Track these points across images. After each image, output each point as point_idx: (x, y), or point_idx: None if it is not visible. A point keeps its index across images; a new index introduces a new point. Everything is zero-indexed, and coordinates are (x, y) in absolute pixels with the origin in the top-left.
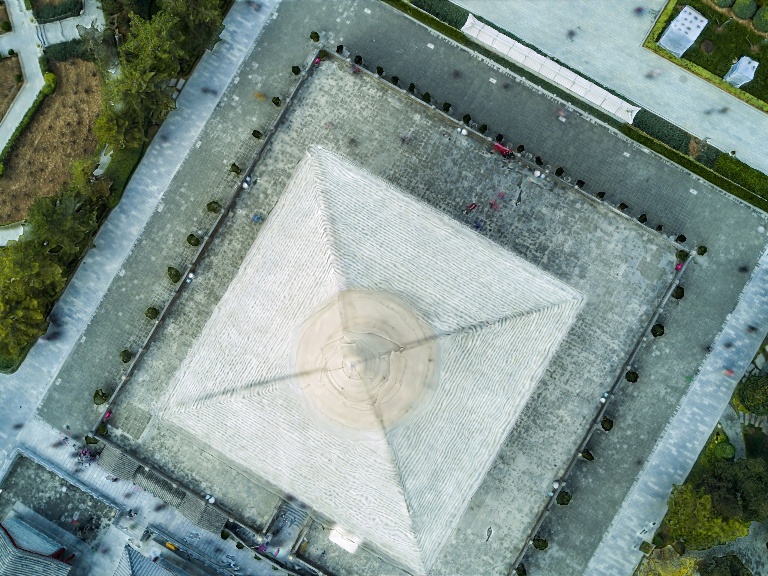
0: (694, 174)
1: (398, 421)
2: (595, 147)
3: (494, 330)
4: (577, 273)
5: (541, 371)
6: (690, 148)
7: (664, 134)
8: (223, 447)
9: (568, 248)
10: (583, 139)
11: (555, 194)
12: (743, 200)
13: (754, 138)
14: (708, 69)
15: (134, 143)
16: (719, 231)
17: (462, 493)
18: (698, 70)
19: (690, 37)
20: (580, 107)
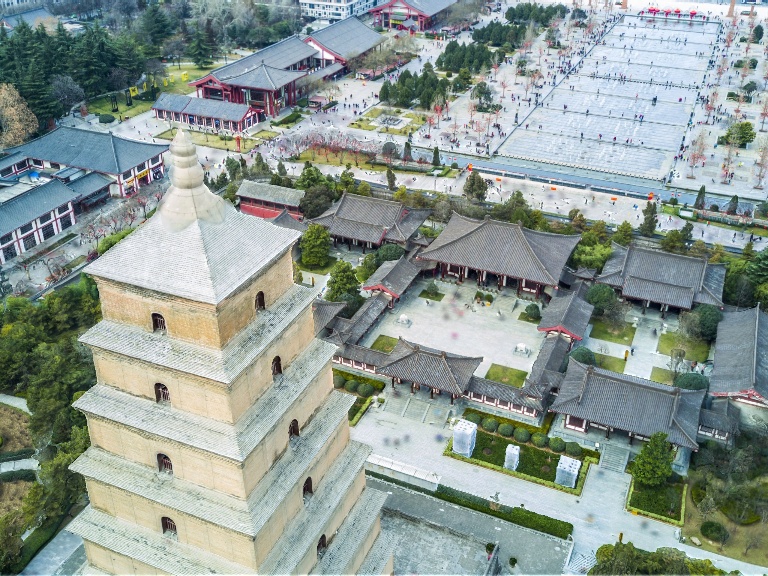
0: (495, 518)
1: (204, 214)
2: (417, 507)
3: (254, 219)
4: (409, 570)
5: (281, 248)
6: (491, 508)
7: (468, 499)
8: (115, 271)
9: (400, 554)
10: (407, 503)
11: (385, 521)
12: (537, 531)
13: (537, 500)
14: (491, 462)
15: (52, 513)
16: (525, 552)
17: (239, 276)
18: (484, 463)
19: (467, 432)
20: (402, 485)
